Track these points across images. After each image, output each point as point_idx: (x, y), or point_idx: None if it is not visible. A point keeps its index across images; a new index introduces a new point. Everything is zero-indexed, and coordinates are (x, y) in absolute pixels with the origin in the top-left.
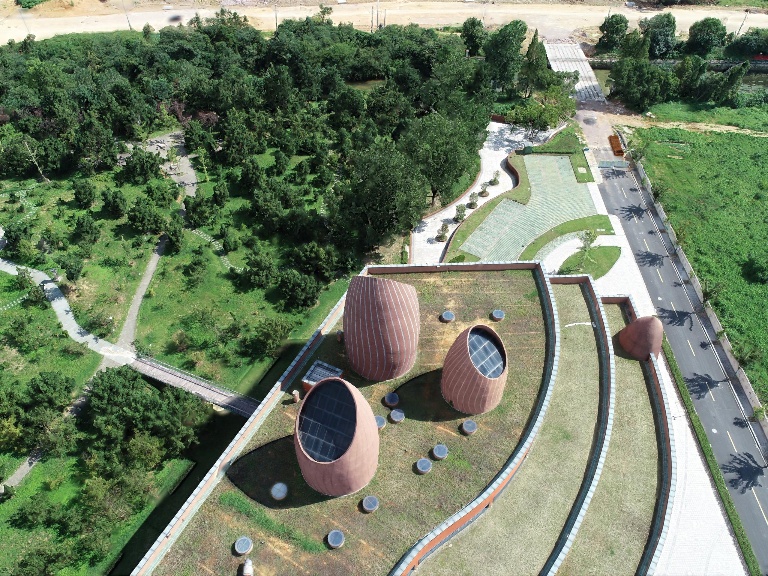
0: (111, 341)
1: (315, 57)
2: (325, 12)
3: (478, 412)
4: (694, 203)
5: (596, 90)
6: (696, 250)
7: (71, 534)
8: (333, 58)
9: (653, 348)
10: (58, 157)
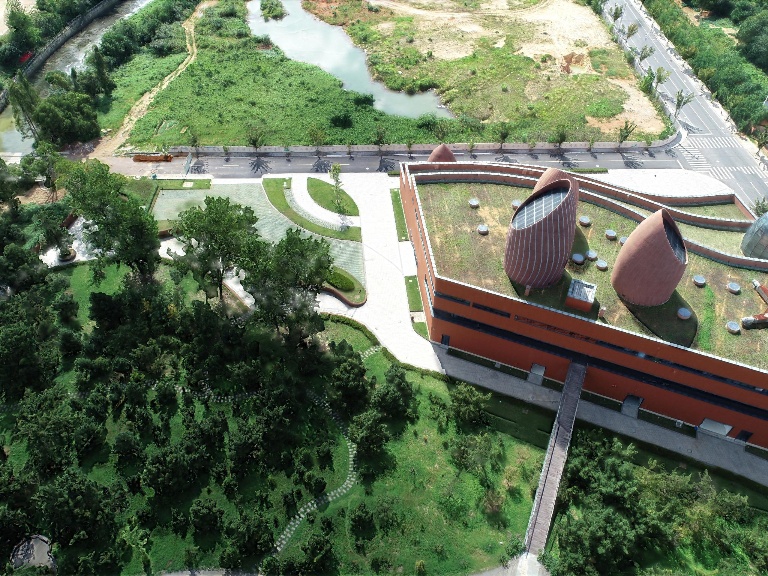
0: None
1: None
2: None
3: None
4: None
5: None
6: None
7: (732, 550)
8: None
9: None
10: None
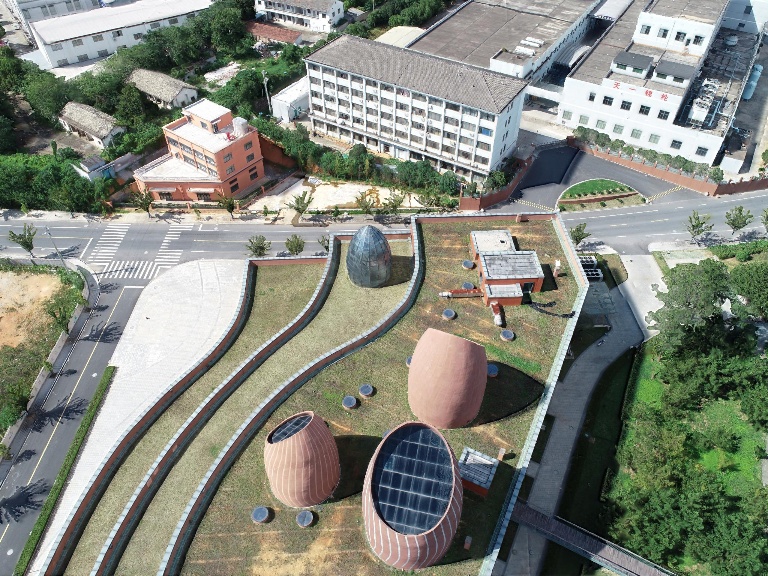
0: None
1: None
2: None
3: None
4: None
5: None
6: None
7: None
8: None
9: None
10: None
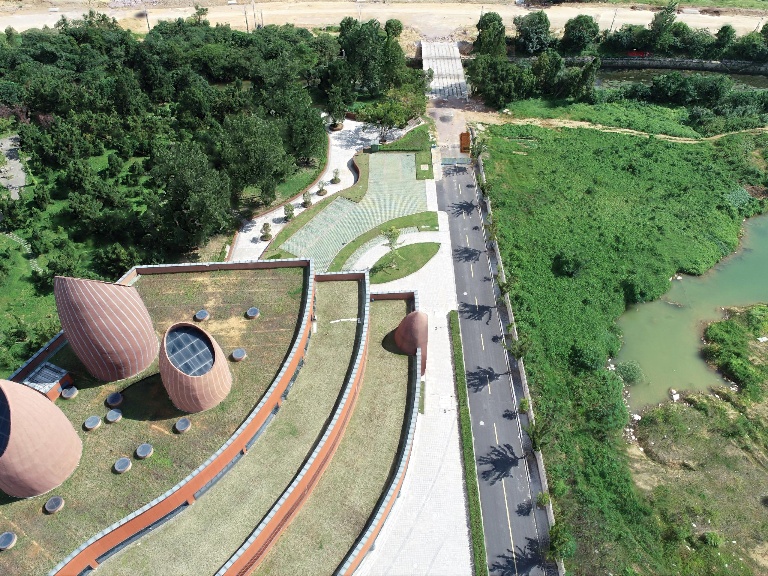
0: None
1: (183, 58)
2: (201, 13)
3: (197, 410)
4: (525, 198)
5: (461, 88)
6: (514, 245)
7: None
8: (202, 59)
9: (419, 343)
10: None
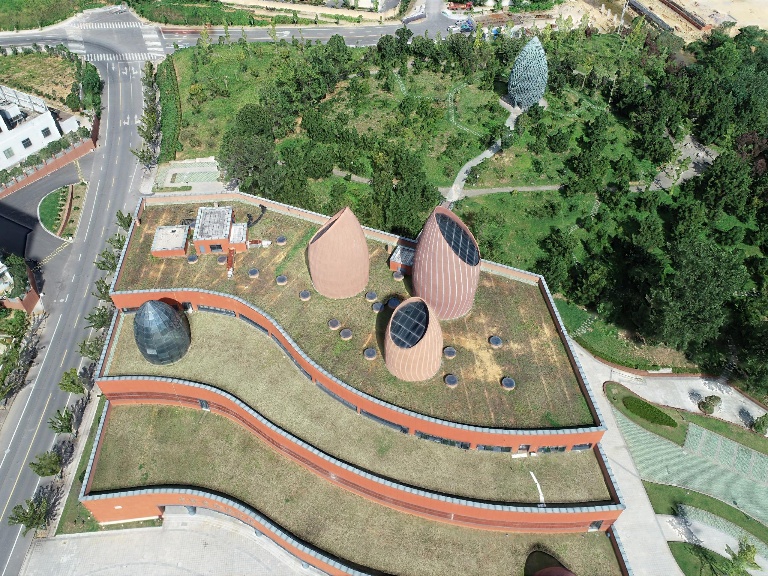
0: (465, 187)
1: None
2: None
3: None
4: None
5: None
6: None
7: None
8: None
9: None
10: (629, 102)
